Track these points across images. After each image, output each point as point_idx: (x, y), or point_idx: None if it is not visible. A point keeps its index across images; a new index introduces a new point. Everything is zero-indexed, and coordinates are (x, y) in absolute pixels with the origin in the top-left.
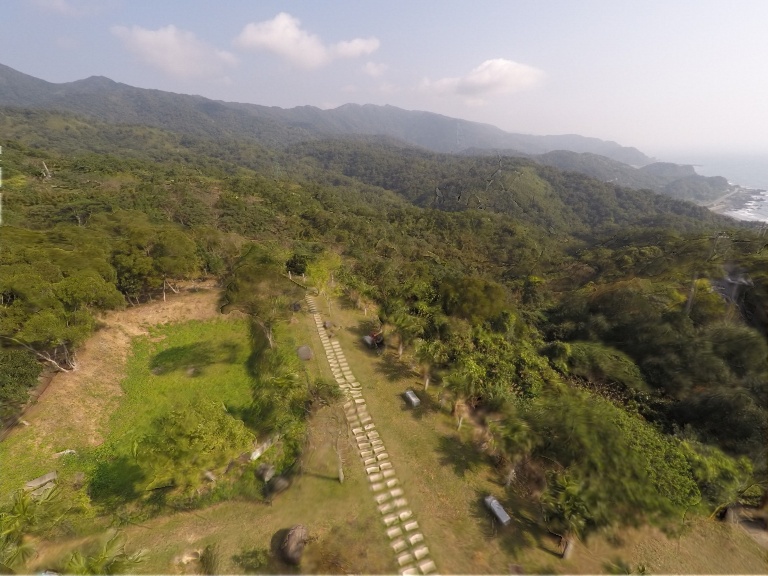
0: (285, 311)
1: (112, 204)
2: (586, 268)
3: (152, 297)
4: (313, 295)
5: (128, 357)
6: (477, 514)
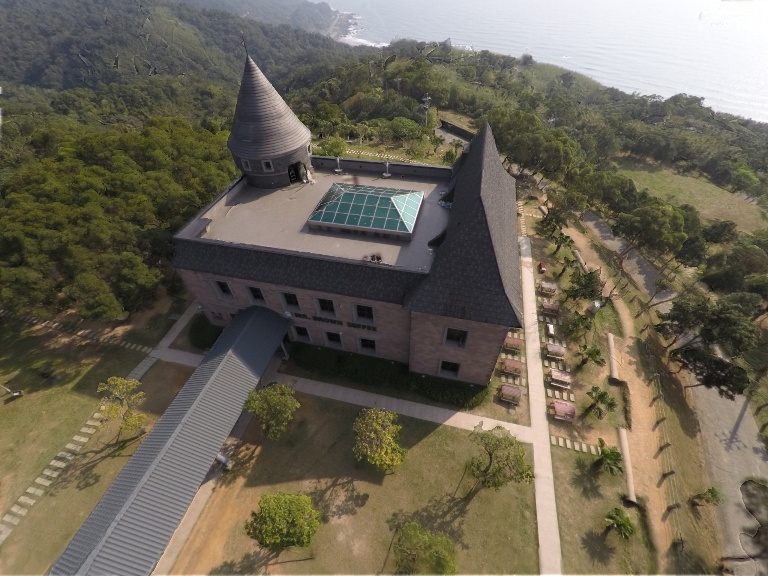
0: None
1: None
2: (304, 105)
3: None
4: None
5: None
6: (387, 151)
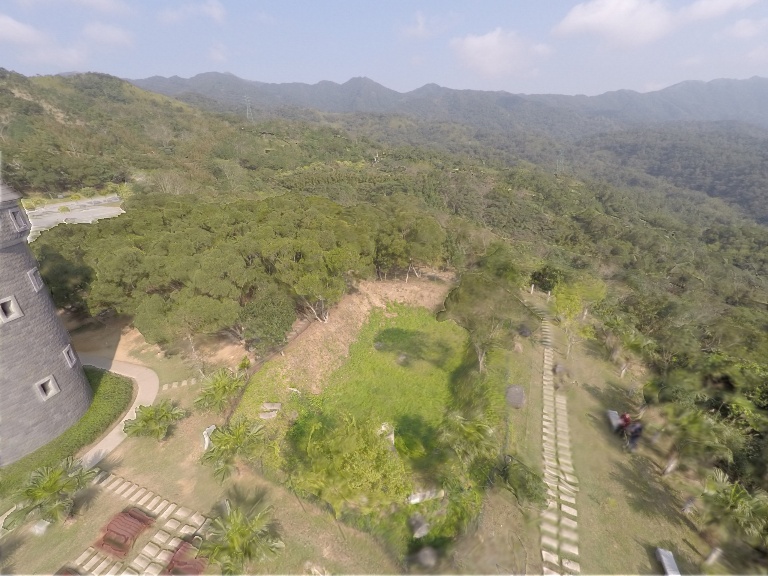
0: (506, 339)
1: (409, 186)
2: None
3: (397, 276)
4: (553, 322)
5: (364, 324)
6: None
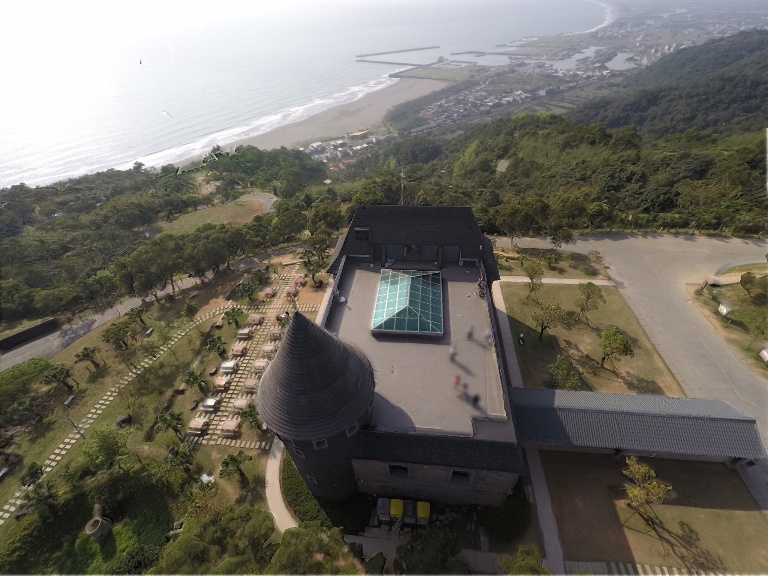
0: None
1: None
2: None
3: None
4: None
5: None
6: None
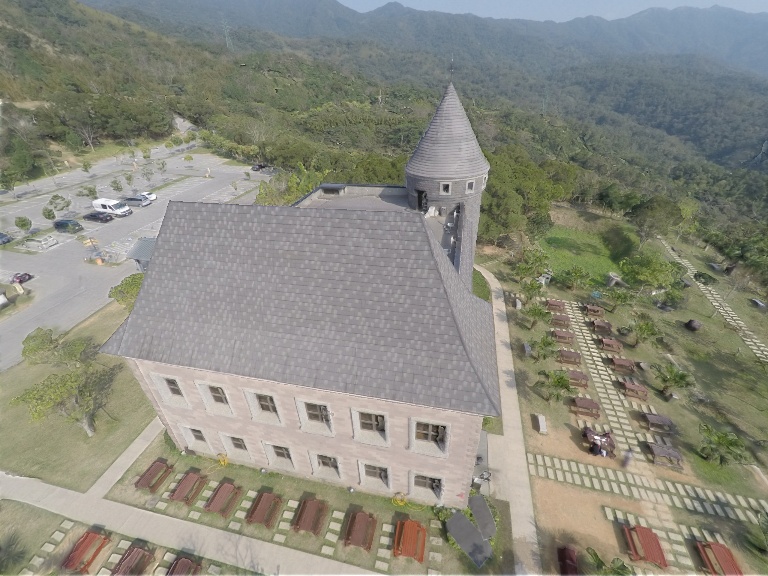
0: None
1: (423, 128)
2: None
3: None
4: None
5: None
6: None
